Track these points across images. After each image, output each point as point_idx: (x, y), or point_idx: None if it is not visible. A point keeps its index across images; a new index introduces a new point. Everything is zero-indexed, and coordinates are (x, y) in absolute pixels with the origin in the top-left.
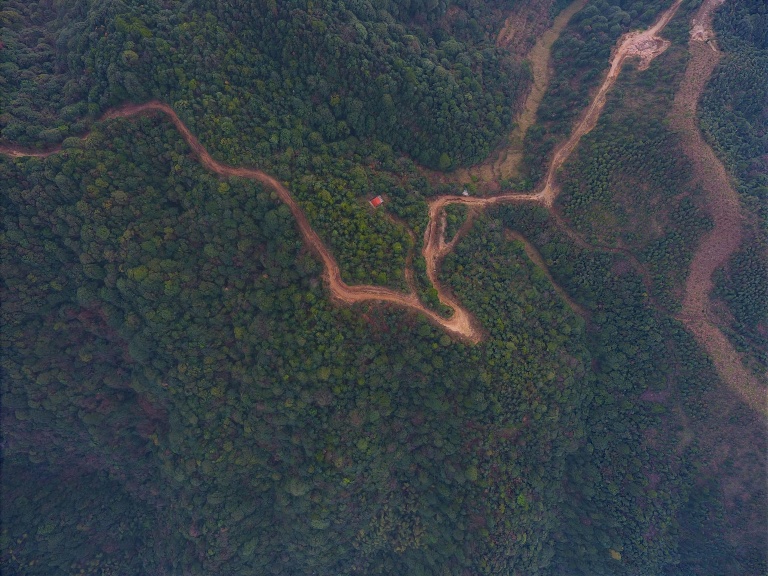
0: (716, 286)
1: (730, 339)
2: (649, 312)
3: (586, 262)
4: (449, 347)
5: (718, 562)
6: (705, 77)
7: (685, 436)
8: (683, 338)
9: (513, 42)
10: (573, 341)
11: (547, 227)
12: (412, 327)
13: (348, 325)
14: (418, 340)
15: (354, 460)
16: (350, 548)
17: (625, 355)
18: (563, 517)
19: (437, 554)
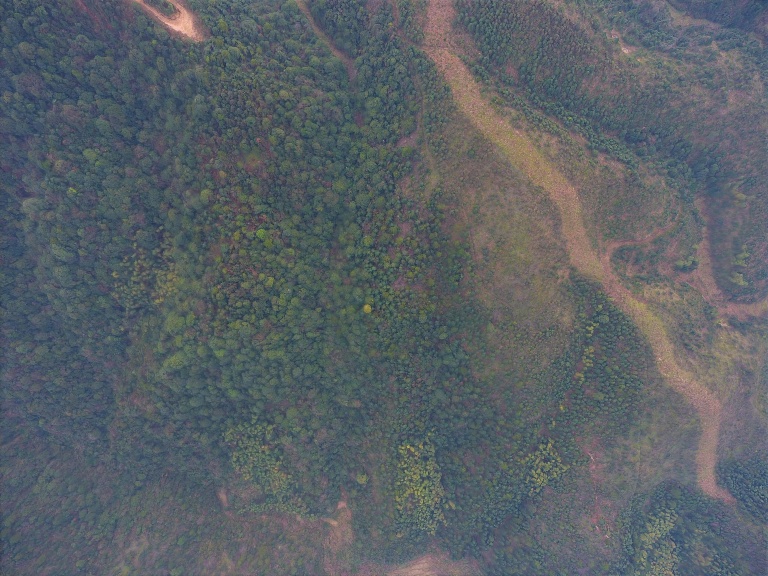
0: (458, 13)
1: (470, 69)
2: (394, 42)
3: None
4: (169, 45)
5: (480, 332)
6: None
7: (432, 179)
8: (423, 66)
9: None
10: (326, 79)
11: None
12: (133, 24)
13: (57, 5)
14: (139, 37)
15: (82, 171)
16: (113, 302)
17: (380, 99)
18: (329, 282)
19: (181, 292)
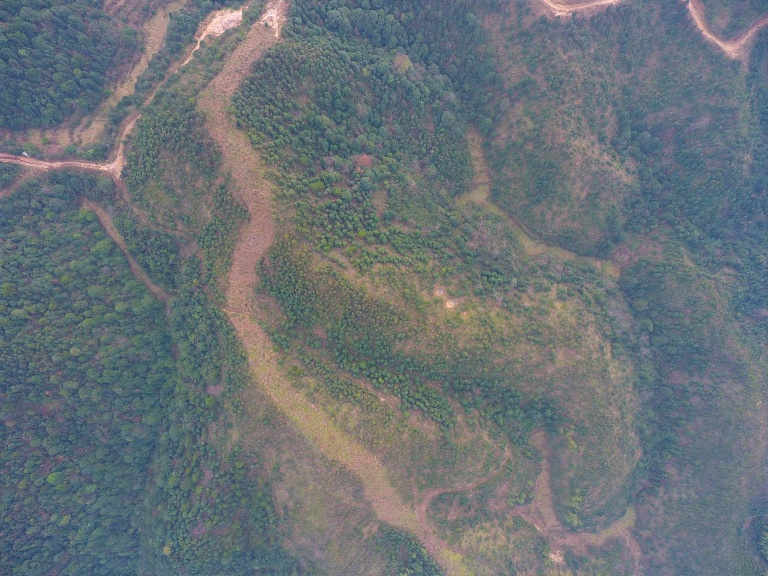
0: (260, 280)
1: (269, 337)
2: (198, 300)
3: (146, 241)
4: None
5: (289, 572)
6: (251, 60)
7: (233, 434)
8: (223, 330)
9: (124, 8)
10: (135, 322)
11: (116, 200)
12: None
13: None
14: None
15: None
16: None
17: (190, 343)
18: (142, 506)
19: None
